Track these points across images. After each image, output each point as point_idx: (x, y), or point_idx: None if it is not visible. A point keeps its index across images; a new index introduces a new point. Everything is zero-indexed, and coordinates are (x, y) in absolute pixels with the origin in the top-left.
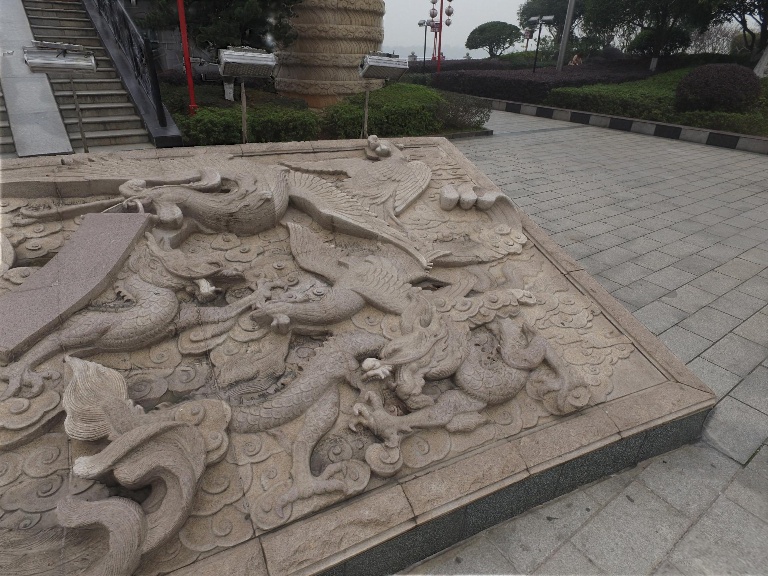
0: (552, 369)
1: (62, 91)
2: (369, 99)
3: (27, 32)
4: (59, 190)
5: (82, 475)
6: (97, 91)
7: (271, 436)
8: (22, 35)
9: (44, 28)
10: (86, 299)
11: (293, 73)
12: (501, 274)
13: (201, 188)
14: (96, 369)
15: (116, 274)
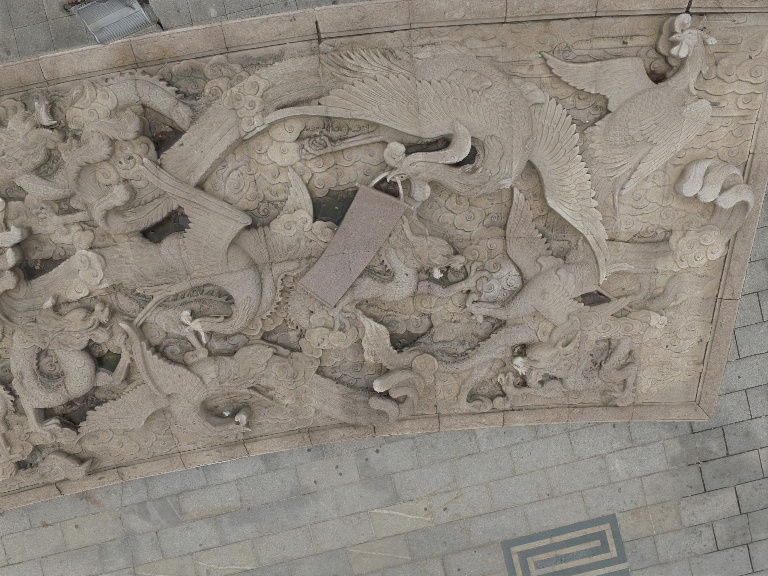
0: (624, 384)
1: None
2: None
3: None
4: (329, 117)
5: None
6: None
7: (453, 376)
8: None
9: None
10: None
11: None
12: (664, 285)
13: (451, 163)
14: (375, 327)
15: None
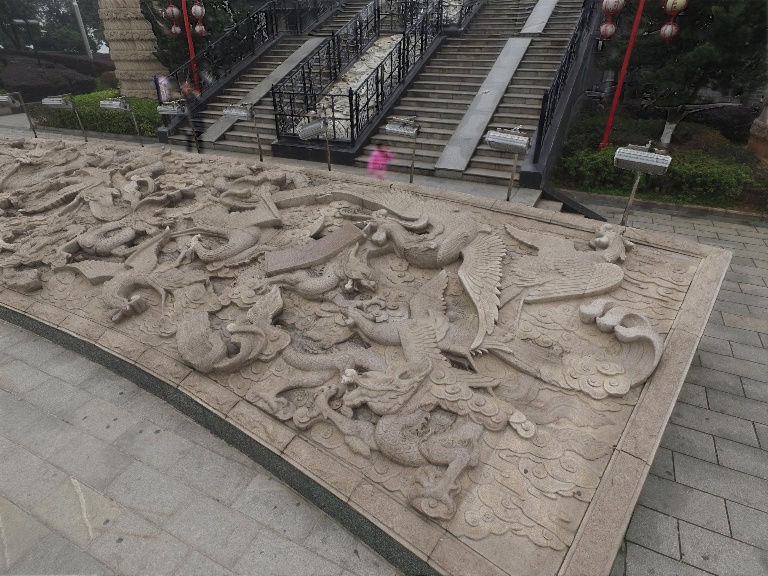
0: None
1: (498, 123)
2: None
3: (510, 75)
4: (363, 203)
5: (227, 328)
6: None
7: (289, 369)
8: (505, 78)
9: (525, 71)
10: (309, 264)
11: None
12: (547, 400)
13: (407, 227)
14: (277, 296)
15: (331, 258)
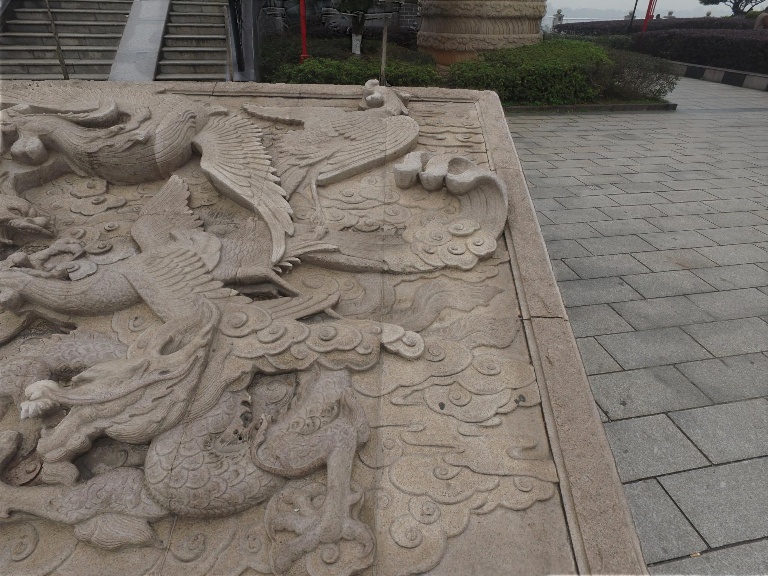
0: None
1: (176, 34)
2: (507, 56)
3: None
4: None
5: None
6: (206, 35)
7: None
8: None
9: None
10: None
11: (432, 25)
12: (411, 296)
13: (79, 120)
14: None
15: None
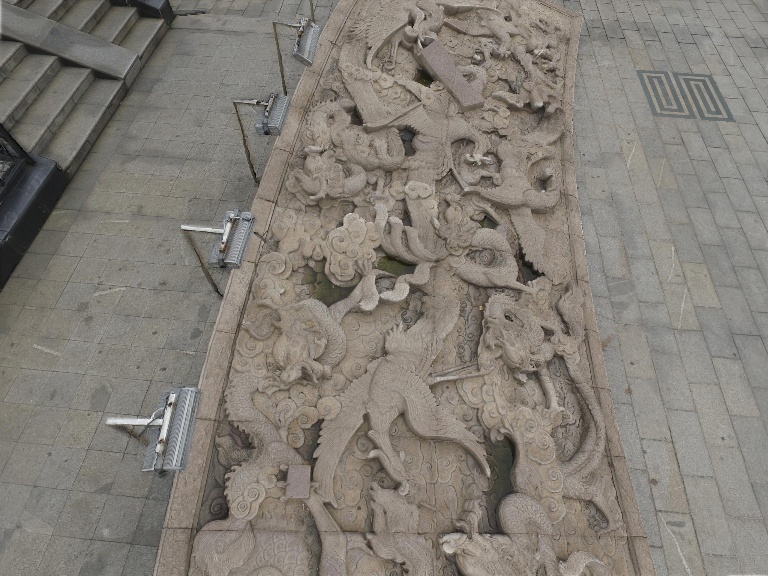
0: (557, 29)
1: None
2: None
3: None
4: None
5: None
6: None
7: None
8: None
9: None
10: None
11: None
12: (507, 3)
13: None
14: None
15: None
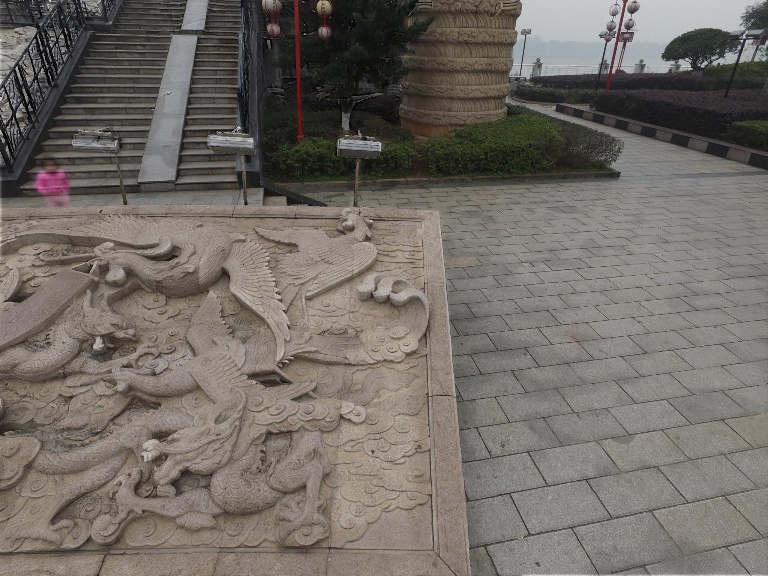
0: None
1: (194, 125)
2: (474, 133)
3: (188, 74)
4: (72, 241)
5: None
6: (218, 126)
7: (55, 480)
8: (183, 77)
9: (203, 70)
10: (23, 337)
11: (412, 102)
12: (362, 380)
13: (148, 256)
14: None
15: (55, 320)
